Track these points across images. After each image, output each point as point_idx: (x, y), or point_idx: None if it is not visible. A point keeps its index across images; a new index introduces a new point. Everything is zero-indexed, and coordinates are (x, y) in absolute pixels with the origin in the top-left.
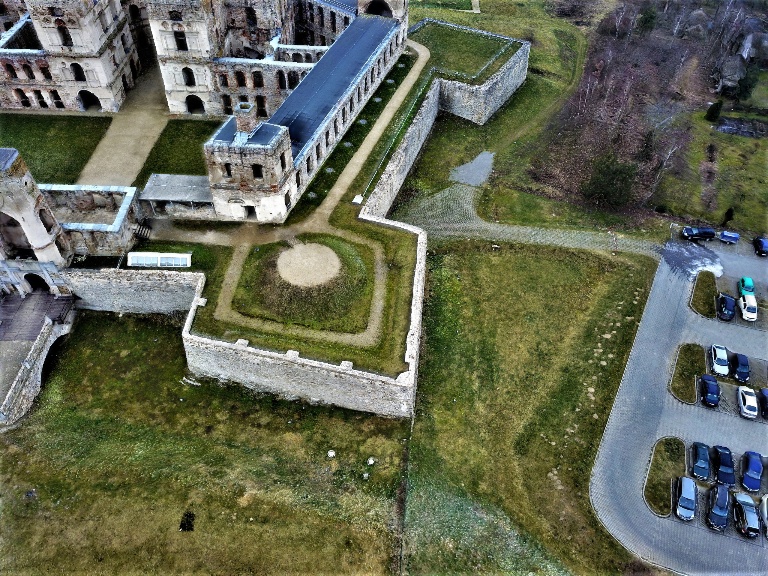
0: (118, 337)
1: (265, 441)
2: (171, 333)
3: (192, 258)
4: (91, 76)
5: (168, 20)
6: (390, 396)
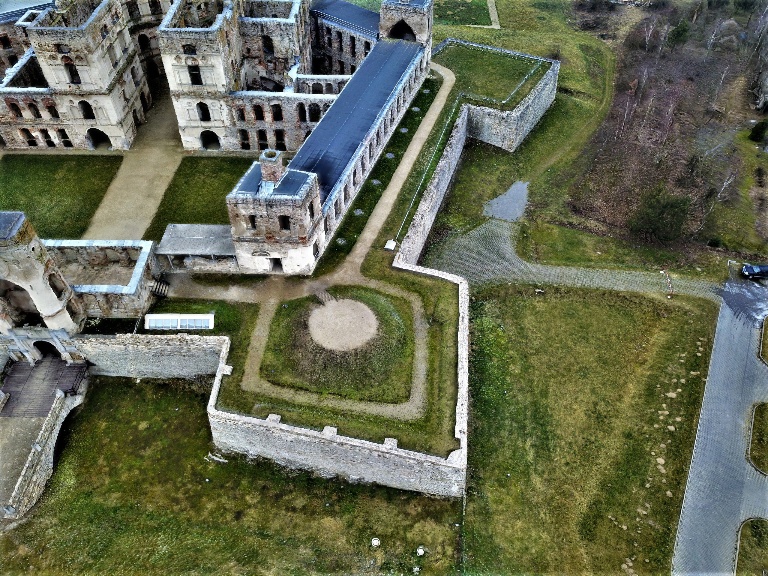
0: (136, 406)
1: (301, 528)
2: (193, 400)
3: (215, 319)
4: (100, 114)
5: (181, 54)
6: (439, 476)
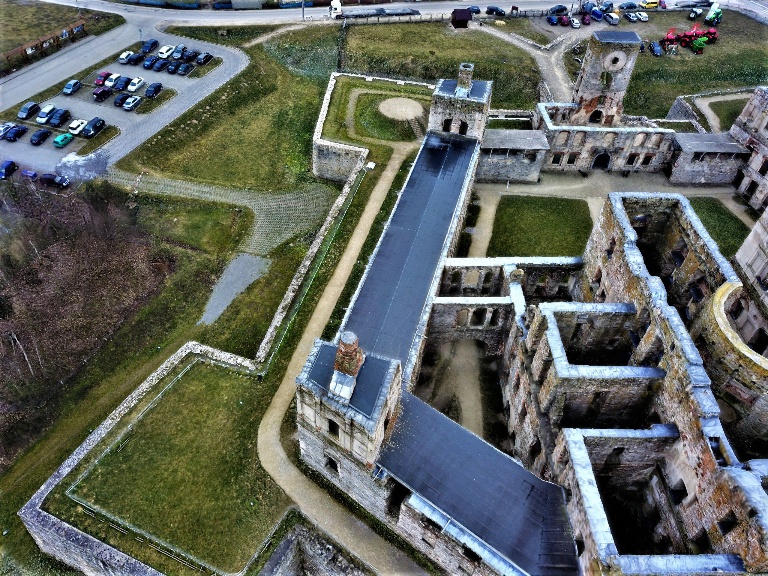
0: None
1: None
2: None
3: None
4: None
5: None
6: None
